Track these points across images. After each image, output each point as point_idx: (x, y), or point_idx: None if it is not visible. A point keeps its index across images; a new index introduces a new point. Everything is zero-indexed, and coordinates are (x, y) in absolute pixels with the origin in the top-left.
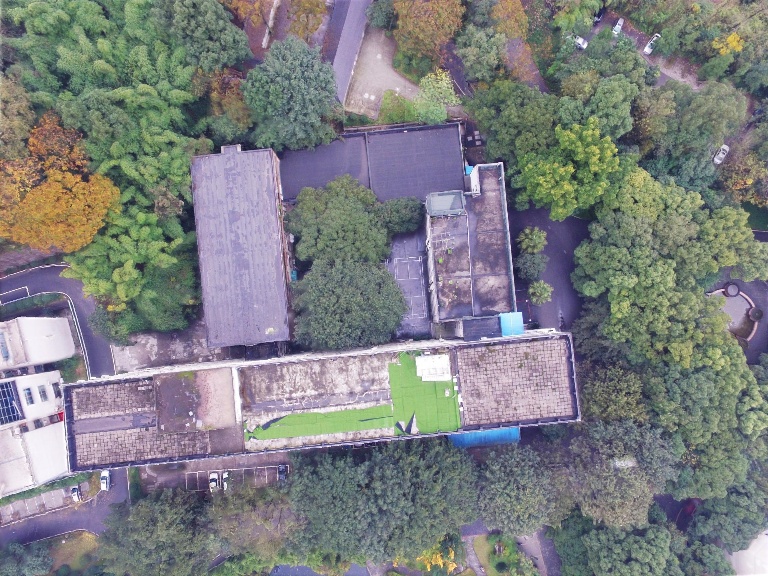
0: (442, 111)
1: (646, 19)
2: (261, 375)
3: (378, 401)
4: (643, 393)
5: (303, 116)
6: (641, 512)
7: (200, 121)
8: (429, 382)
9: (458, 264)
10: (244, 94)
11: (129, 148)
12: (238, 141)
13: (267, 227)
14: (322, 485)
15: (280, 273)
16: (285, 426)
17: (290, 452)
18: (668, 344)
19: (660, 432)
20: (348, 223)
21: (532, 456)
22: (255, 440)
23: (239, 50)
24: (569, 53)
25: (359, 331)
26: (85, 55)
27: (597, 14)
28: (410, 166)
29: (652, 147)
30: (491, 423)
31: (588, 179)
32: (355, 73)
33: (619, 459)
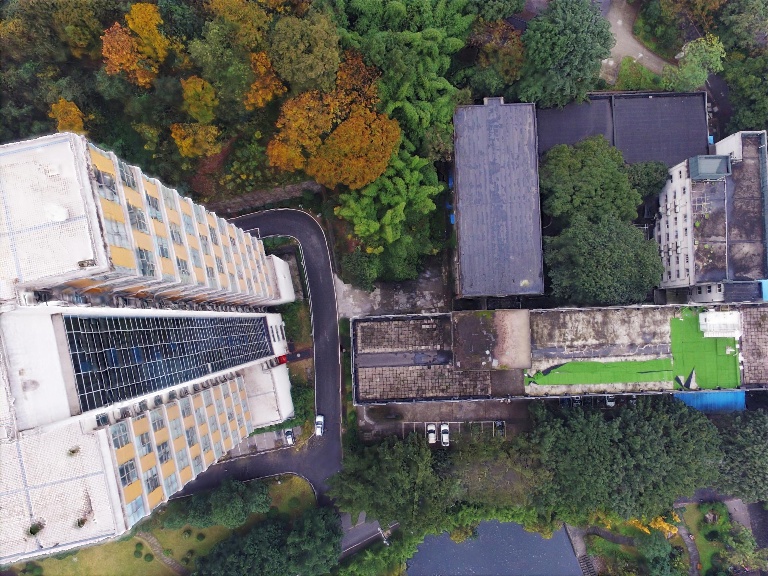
0: (704, 77)
1: None
2: (544, 321)
3: (658, 354)
4: None
5: (577, 71)
6: None
7: (458, 72)
8: (710, 339)
9: (714, 229)
10: (532, 44)
11: (408, 92)
12: (489, 95)
13: (526, 180)
14: (577, 437)
15: (537, 227)
16: (565, 373)
17: (533, 405)
18: None
19: None
20: (609, 181)
21: None
22: (535, 385)
23: (520, 2)
24: None
25: (624, 287)
26: None
27: None
28: (654, 131)
29: None
30: None
31: None
32: None
33: None
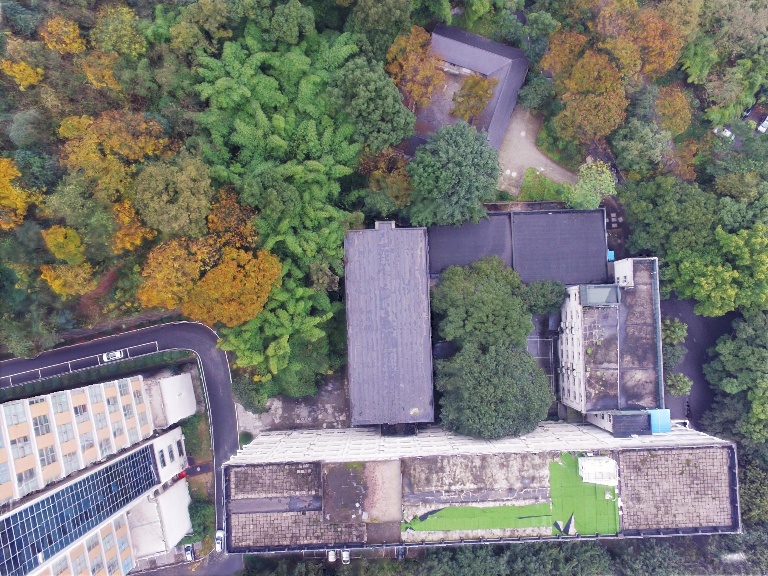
0: (597, 201)
1: None
2: (421, 465)
3: (537, 499)
4: None
5: (465, 200)
6: None
7: (352, 193)
8: (589, 483)
9: (606, 356)
10: (415, 178)
11: (292, 222)
12: None
13: (417, 306)
14: (463, 573)
15: (428, 353)
16: (443, 518)
17: None
18: None
19: None
20: (500, 308)
21: (672, 555)
22: (412, 531)
23: (407, 131)
24: (724, 150)
25: (511, 421)
26: (260, 130)
27: (747, 109)
28: (554, 249)
29: None
30: (650, 529)
31: (748, 283)
32: (498, 149)
33: (766, 568)
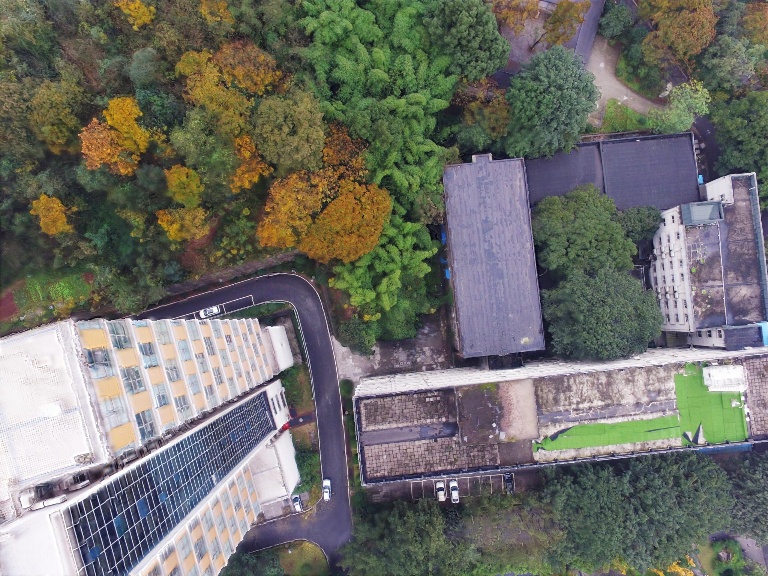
0: (691, 121)
1: None
2: (548, 386)
3: (664, 411)
4: None
5: (564, 126)
6: None
7: (444, 130)
8: (715, 392)
9: (710, 273)
10: (518, 104)
11: (396, 157)
12: (477, 150)
13: (520, 236)
14: (588, 495)
15: (534, 282)
16: (573, 437)
17: None
18: None
19: None
20: (603, 233)
21: None
22: (543, 451)
23: (503, 60)
24: None
25: (626, 341)
26: (362, 64)
27: None
28: (644, 175)
29: None
30: None
31: None
32: None
33: None
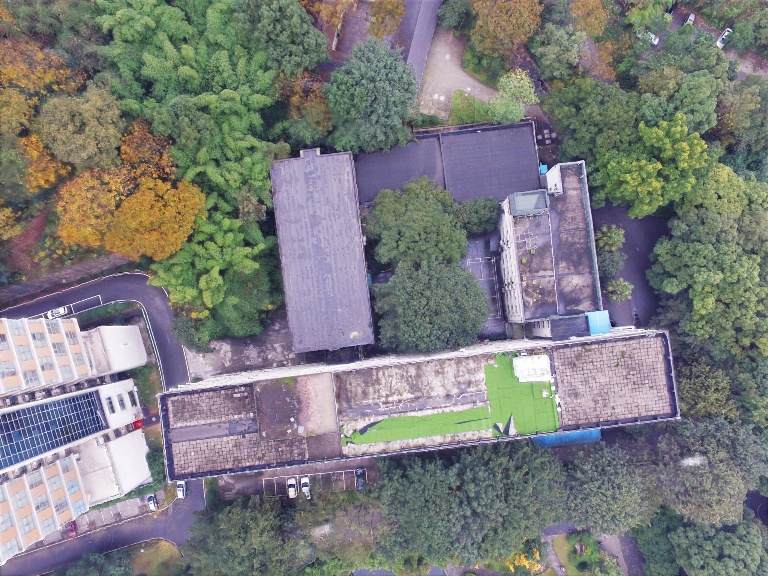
0: (521, 110)
1: (718, 14)
2: (357, 379)
3: (475, 403)
4: (730, 389)
5: (385, 118)
6: (738, 509)
7: (276, 125)
8: (526, 383)
9: (541, 264)
10: (329, 97)
11: (213, 154)
12: (313, 145)
13: (349, 230)
14: (413, 488)
15: (363, 276)
16: (382, 430)
17: None
18: (755, 339)
19: (751, 428)
20: (431, 225)
21: (621, 455)
22: (352, 445)
23: (320, 53)
24: (645, 50)
25: (448, 333)
26: (170, 61)
27: (668, 10)
28: (485, 166)
29: (732, 142)
30: (589, 423)
31: (674, 176)
32: (424, 74)
33: (713, 456)
